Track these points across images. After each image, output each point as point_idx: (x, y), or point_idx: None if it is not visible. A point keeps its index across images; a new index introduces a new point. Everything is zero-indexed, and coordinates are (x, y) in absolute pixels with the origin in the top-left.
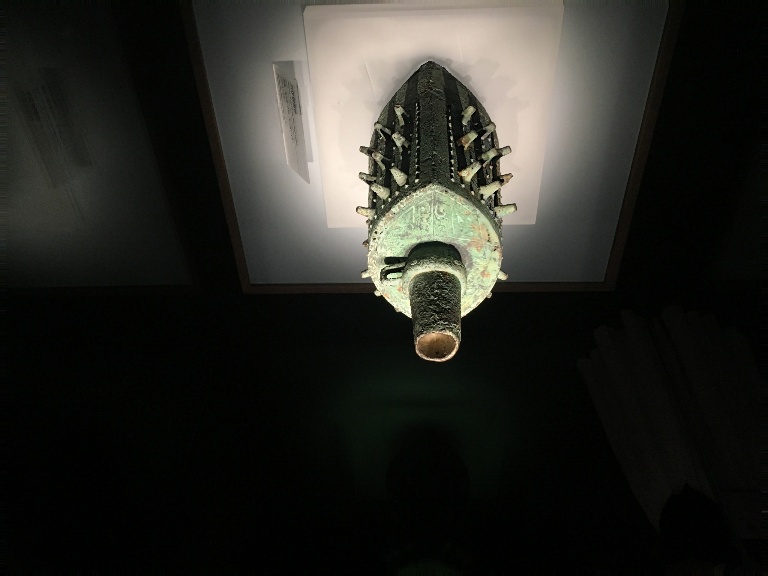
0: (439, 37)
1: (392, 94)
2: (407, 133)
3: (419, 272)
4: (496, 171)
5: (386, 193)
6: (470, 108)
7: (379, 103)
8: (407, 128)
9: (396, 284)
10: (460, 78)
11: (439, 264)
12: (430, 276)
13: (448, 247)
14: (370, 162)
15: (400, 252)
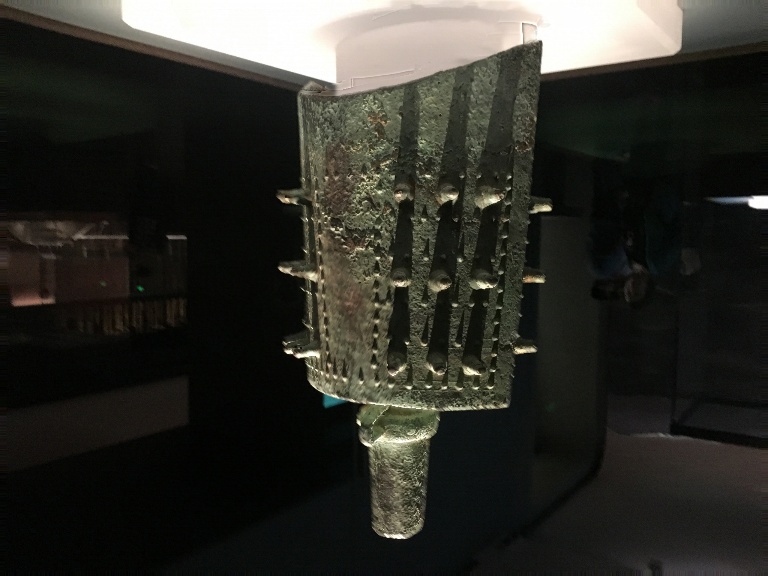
0: (580, 11)
1: (445, 9)
2: (486, 245)
3: (410, 441)
4: None
5: None
6: None
7: (415, 5)
8: (487, 229)
9: None
10: None
11: None
12: (419, 449)
13: None
14: (378, 178)
15: None
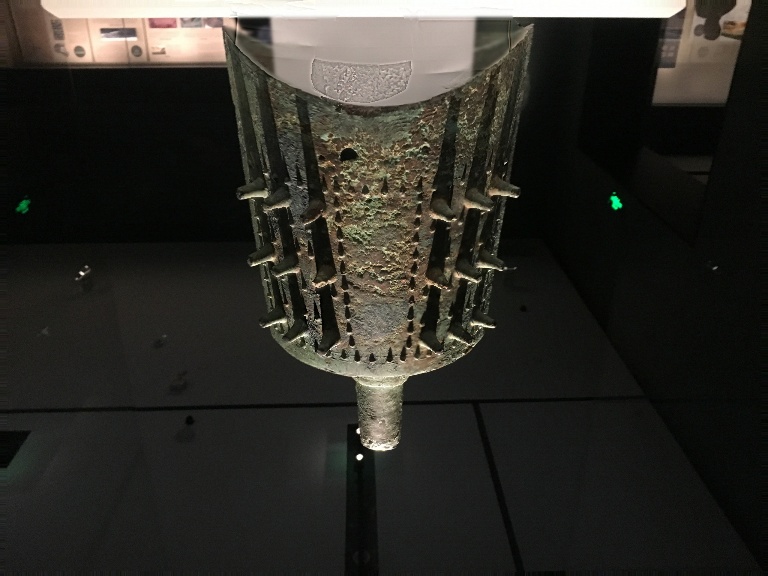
0: None
1: None
2: None
3: None
4: (328, 241)
5: None
6: None
7: None
8: None
9: None
10: (252, 5)
11: None
12: None
13: None
14: None
15: None
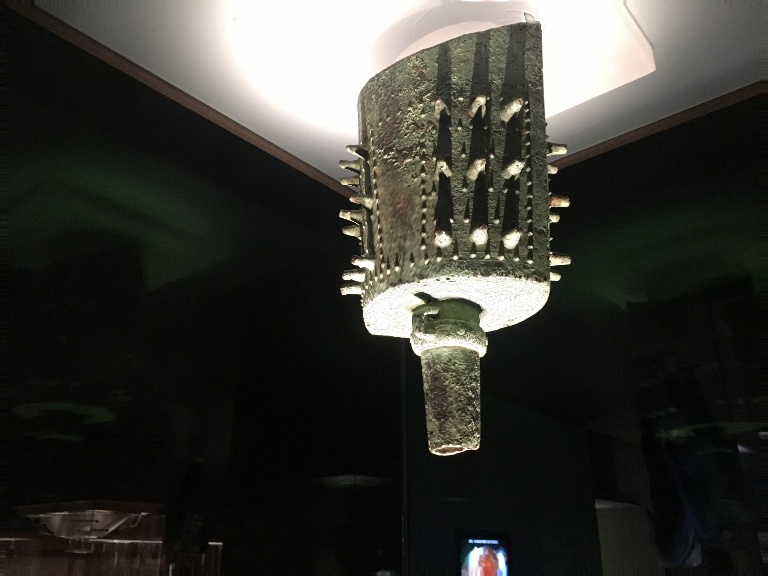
0: (566, 3)
1: (466, 4)
2: (513, 148)
3: (460, 345)
4: None
5: (484, 240)
6: (563, 150)
7: None
8: (512, 136)
9: (426, 338)
10: None
11: (481, 346)
12: (469, 357)
13: (479, 311)
14: (422, 106)
15: (440, 295)
